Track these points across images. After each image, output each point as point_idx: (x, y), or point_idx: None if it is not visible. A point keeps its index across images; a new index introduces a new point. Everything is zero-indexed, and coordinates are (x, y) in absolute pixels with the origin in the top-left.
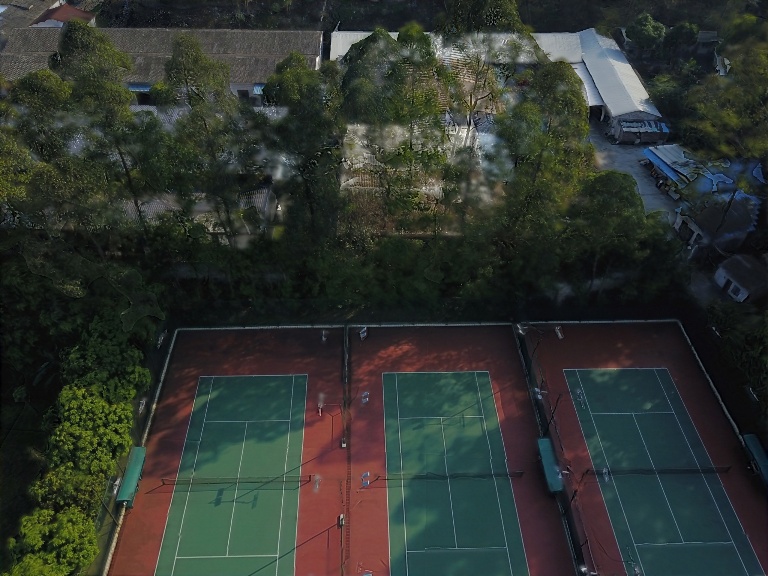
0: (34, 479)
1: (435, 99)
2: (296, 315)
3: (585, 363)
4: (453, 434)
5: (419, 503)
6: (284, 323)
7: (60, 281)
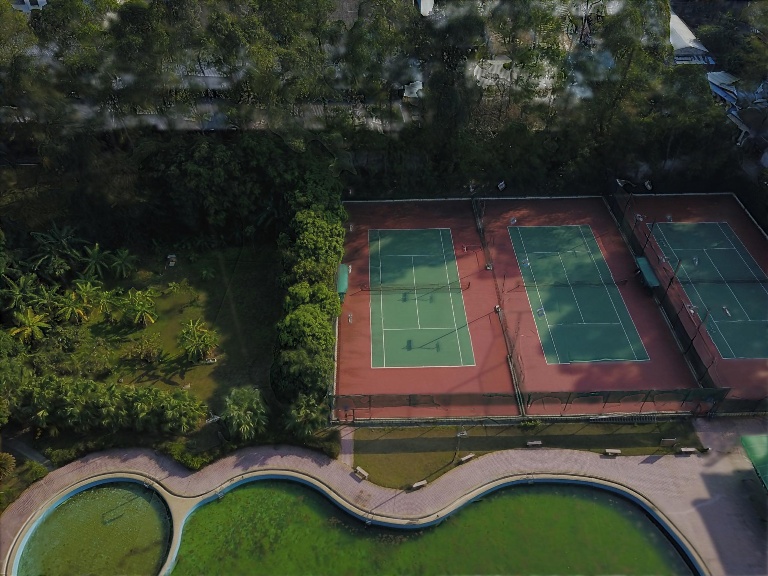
0: (281, 274)
1: (558, 7)
2: (432, 192)
3: (663, 219)
4: (569, 261)
5: (552, 299)
6: (424, 197)
7: (290, 139)
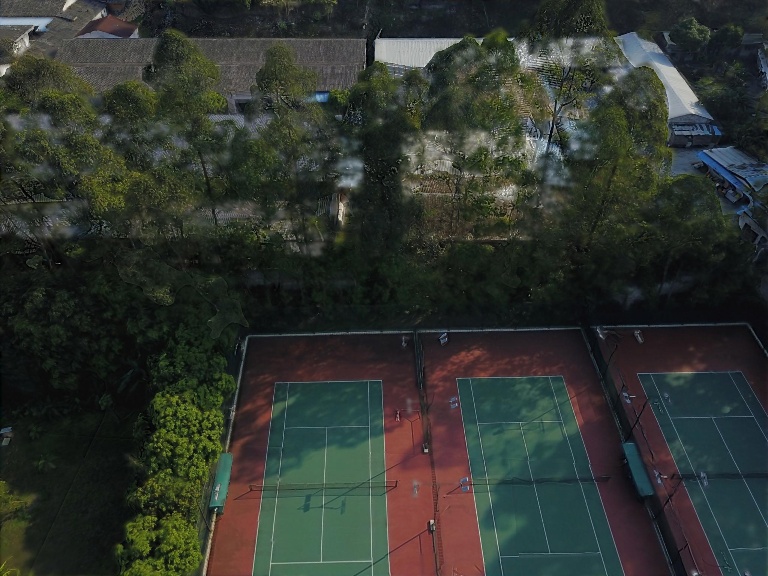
0: (130, 486)
1: (517, 105)
2: (364, 321)
3: (659, 367)
4: (534, 439)
5: (508, 508)
6: (353, 329)
7: (150, 289)
